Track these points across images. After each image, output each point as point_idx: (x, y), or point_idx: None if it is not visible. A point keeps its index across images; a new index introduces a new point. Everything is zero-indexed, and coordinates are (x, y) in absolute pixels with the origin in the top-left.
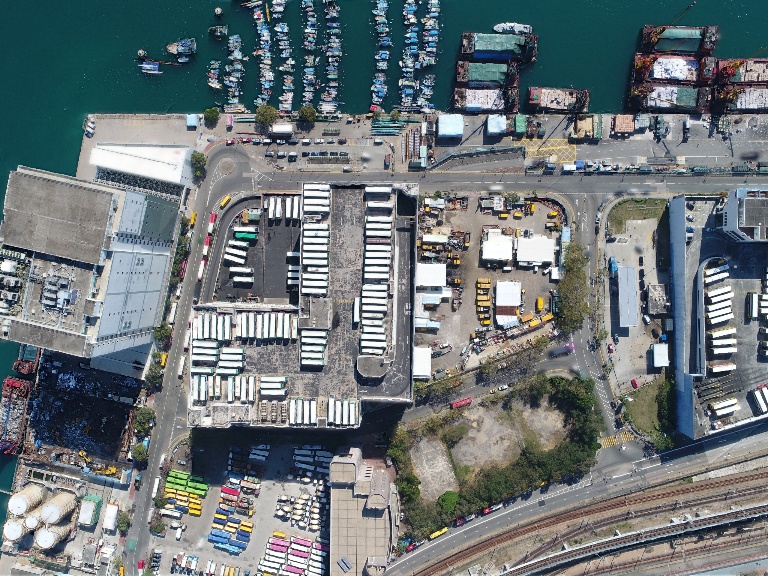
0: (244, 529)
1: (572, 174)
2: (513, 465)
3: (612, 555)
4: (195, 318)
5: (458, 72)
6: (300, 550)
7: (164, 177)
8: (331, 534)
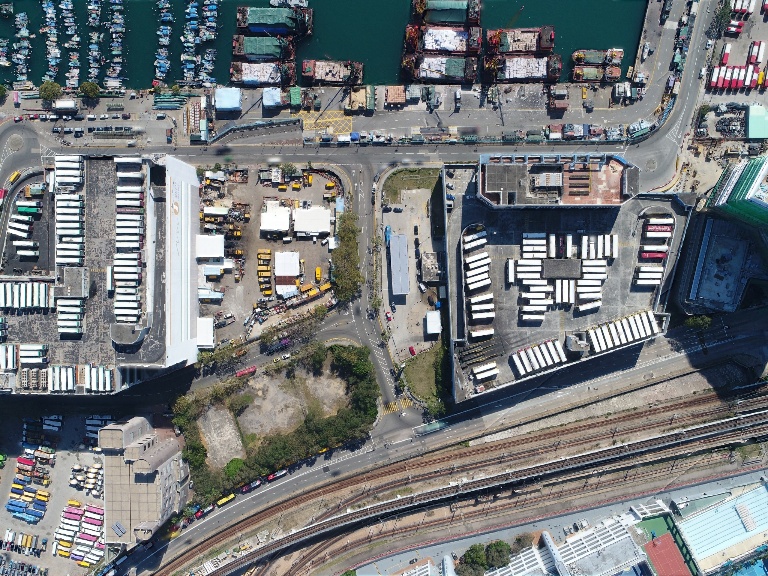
0: (40, 498)
1: (348, 145)
2: (295, 432)
3: (394, 519)
4: None
5: (233, 46)
6: (93, 518)
7: None
8: (105, 500)
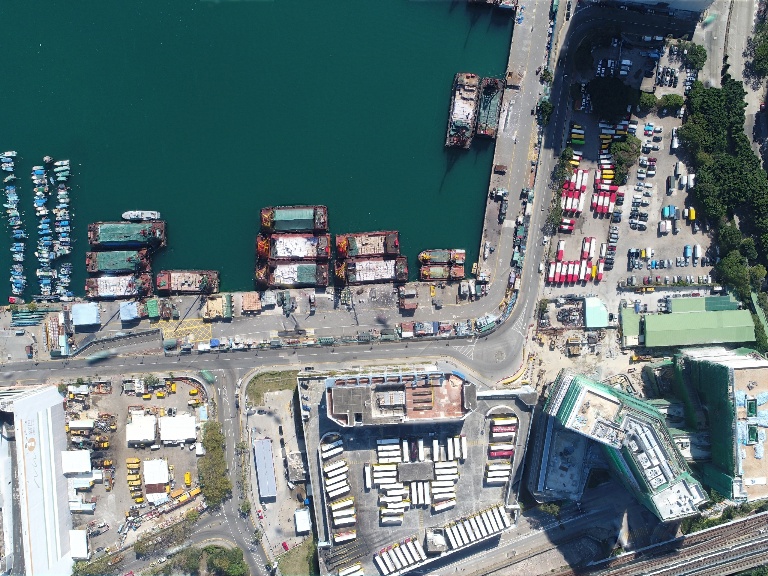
0: None
1: (209, 352)
2: None
3: None
4: None
5: (86, 264)
6: None
7: None
8: None
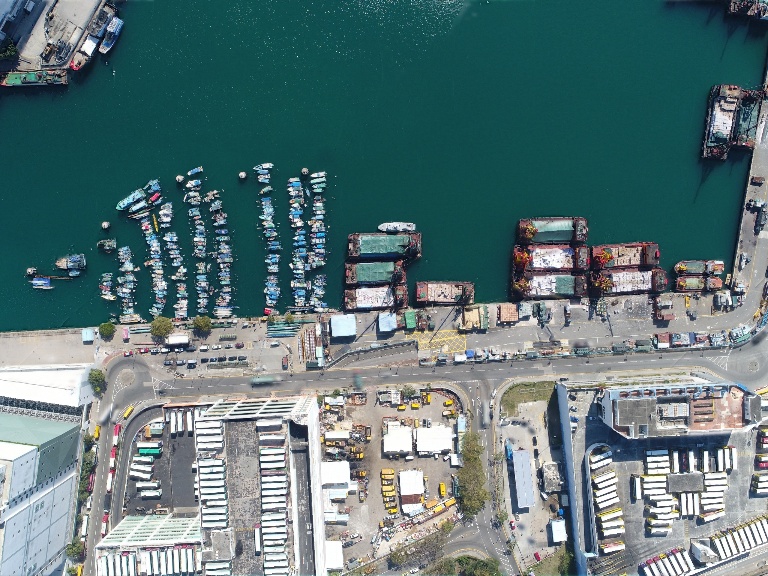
0: None
1: (464, 363)
2: None
3: None
4: (99, 559)
5: (346, 275)
6: None
7: (62, 402)
8: None
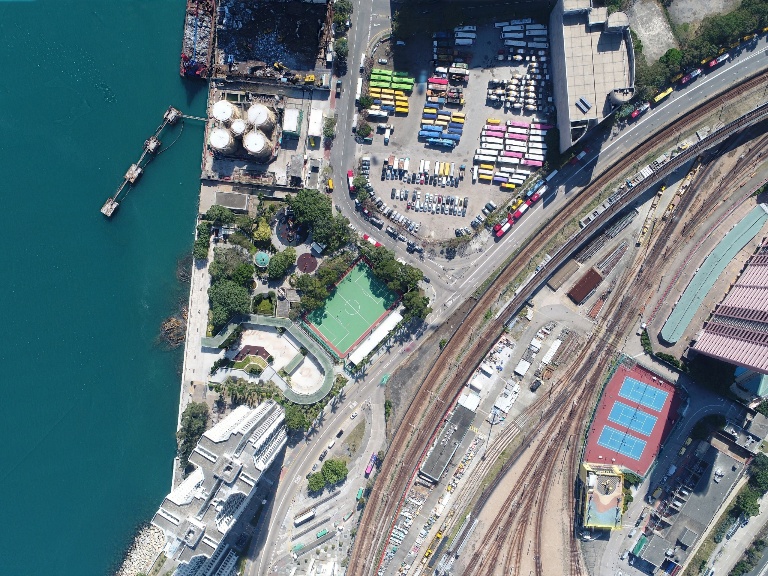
0: (456, 120)
1: None
2: (737, 10)
3: None
4: None
5: None
6: (518, 133)
7: None
8: (566, 74)
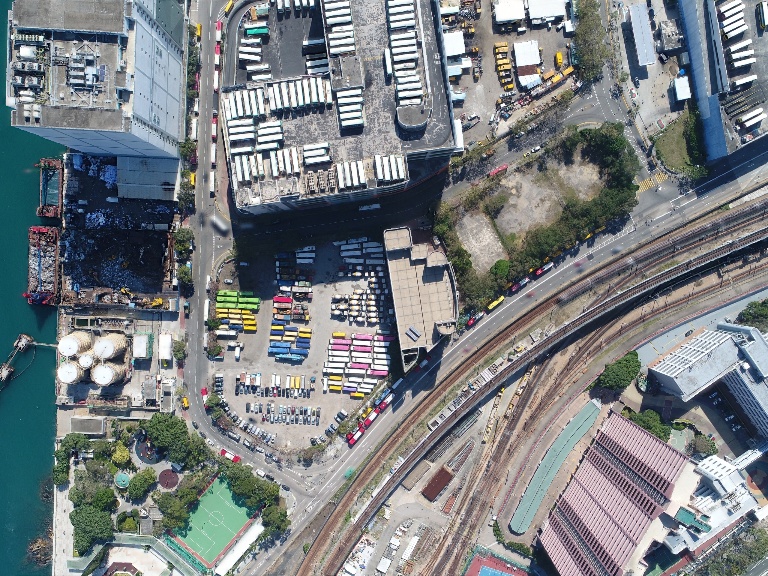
0: (303, 336)
1: None
2: (558, 222)
3: (665, 295)
4: (226, 99)
5: None
6: (362, 345)
7: None
8: (395, 306)
